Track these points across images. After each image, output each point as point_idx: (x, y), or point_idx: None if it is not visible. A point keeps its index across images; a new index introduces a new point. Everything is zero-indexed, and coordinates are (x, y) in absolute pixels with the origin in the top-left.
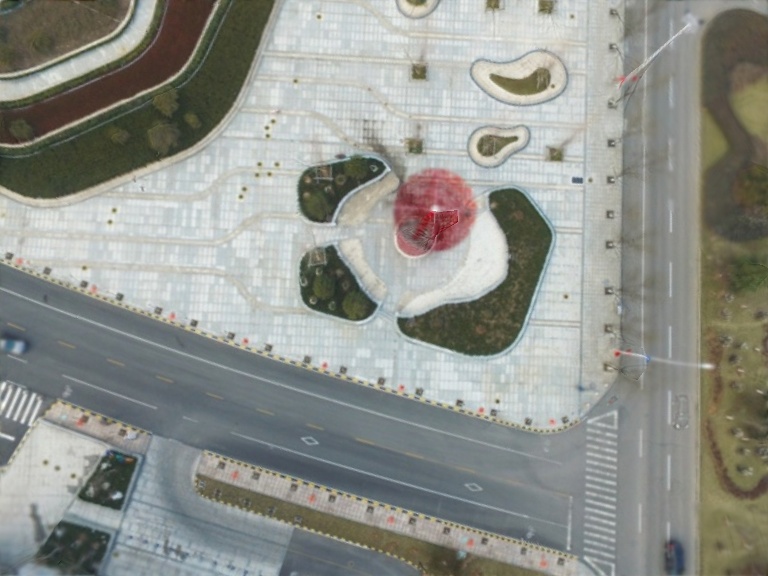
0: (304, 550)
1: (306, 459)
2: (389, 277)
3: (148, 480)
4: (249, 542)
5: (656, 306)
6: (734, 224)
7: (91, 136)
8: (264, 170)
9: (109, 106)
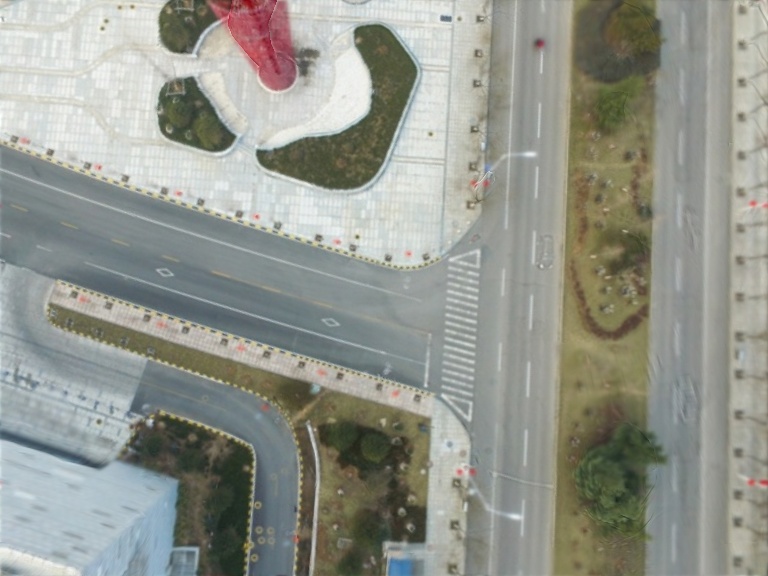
0: (157, 382)
1: (161, 291)
2: (251, 111)
3: None
4: (101, 373)
5: (523, 146)
6: (603, 63)
7: None
8: (127, 3)
9: None
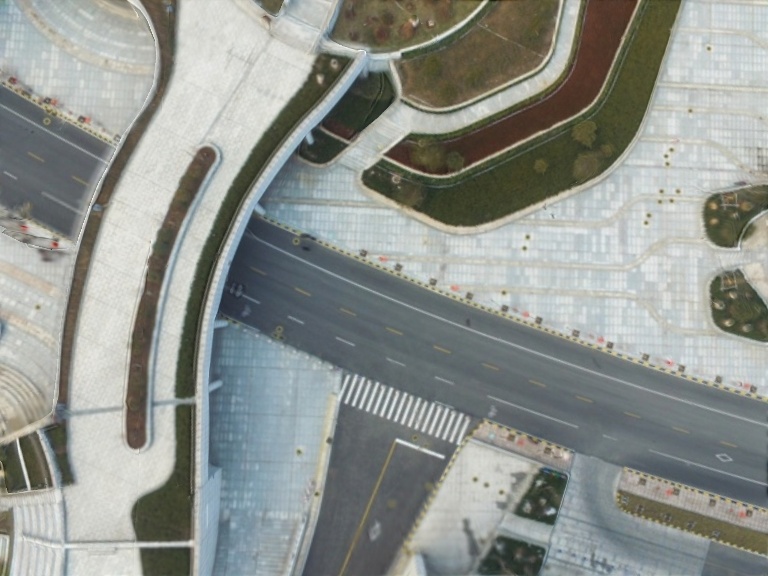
0: (720, 563)
1: (721, 475)
2: None
3: (573, 496)
4: (669, 555)
5: None
6: None
7: (509, 166)
8: (666, 197)
9: (528, 137)
